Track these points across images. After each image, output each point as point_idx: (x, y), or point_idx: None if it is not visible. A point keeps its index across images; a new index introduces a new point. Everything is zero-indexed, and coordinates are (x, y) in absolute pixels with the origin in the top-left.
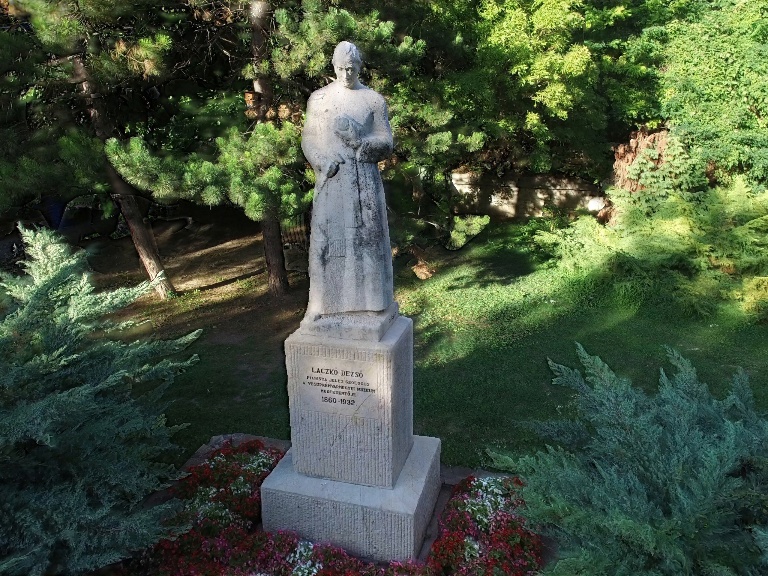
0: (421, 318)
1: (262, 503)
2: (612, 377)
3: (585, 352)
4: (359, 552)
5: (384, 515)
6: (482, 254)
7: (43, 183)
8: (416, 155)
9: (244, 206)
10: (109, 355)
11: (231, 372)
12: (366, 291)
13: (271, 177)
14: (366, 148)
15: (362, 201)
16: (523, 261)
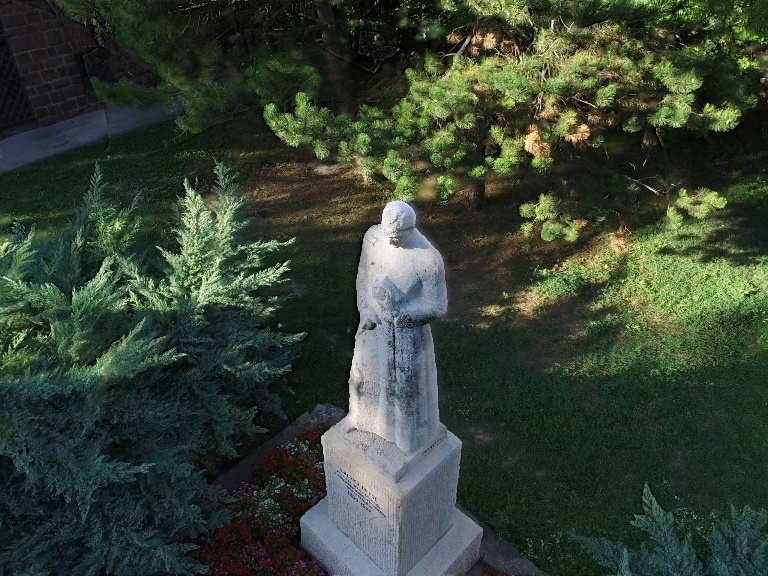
0: (599, 294)
1: (302, 529)
2: None
3: (628, 569)
4: None
5: None
6: (739, 197)
7: (237, 103)
8: (635, 126)
9: (397, 183)
10: (226, 340)
11: None
12: (397, 431)
13: (440, 144)
14: (404, 319)
15: (397, 362)
16: None
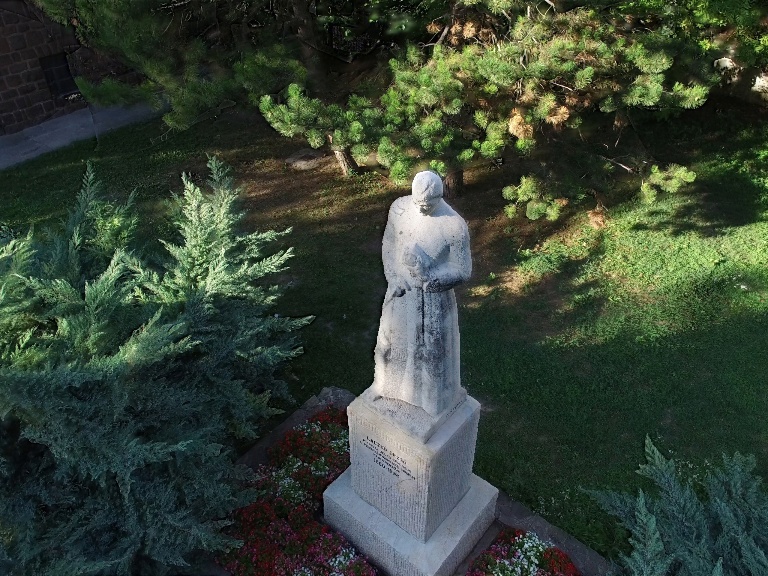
0: (581, 270)
1: (324, 503)
2: (657, 550)
3: (644, 506)
4: (389, 574)
5: (410, 564)
6: (702, 174)
7: (224, 98)
8: (611, 106)
9: (391, 168)
10: (235, 327)
11: (372, 296)
12: (423, 395)
13: (429, 129)
14: (434, 284)
15: (425, 326)
16: (746, 200)
